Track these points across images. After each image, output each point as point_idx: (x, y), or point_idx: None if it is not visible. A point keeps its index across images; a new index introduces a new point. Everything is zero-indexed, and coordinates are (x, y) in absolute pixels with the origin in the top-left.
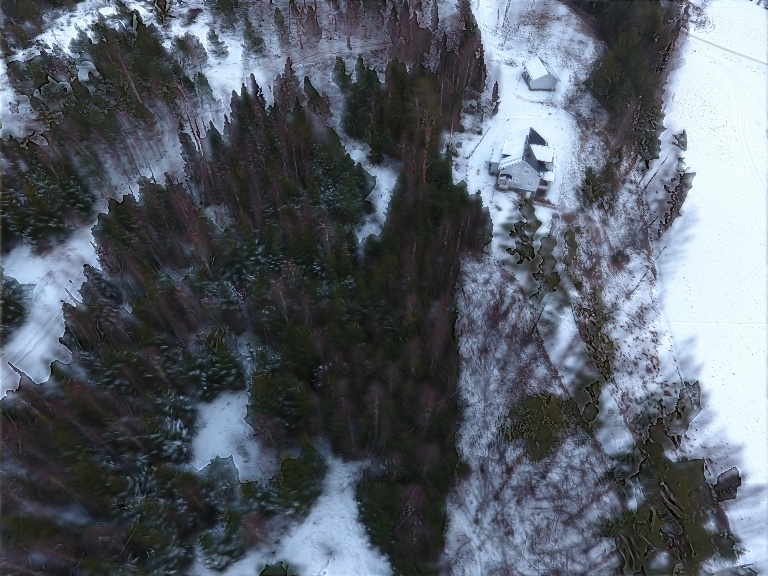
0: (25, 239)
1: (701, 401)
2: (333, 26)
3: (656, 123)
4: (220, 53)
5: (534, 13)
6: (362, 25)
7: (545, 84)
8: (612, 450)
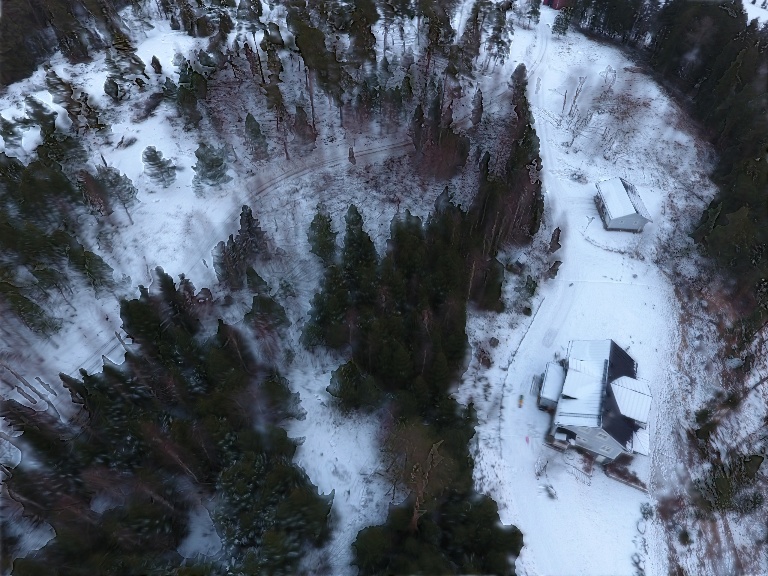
0: None
1: None
2: (338, 120)
3: None
4: (165, 175)
5: (612, 94)
6: (376, 121)
7: (629, 223)
8: None
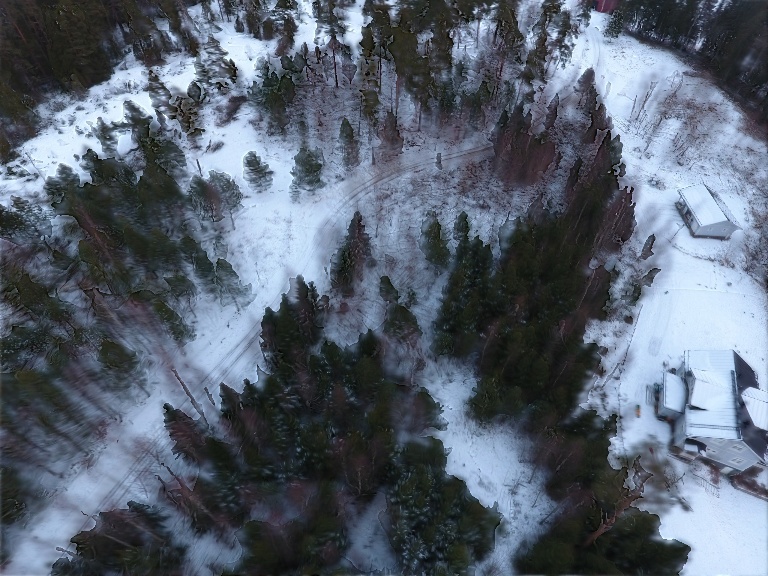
0: None
1: None
2: (416, 124)
3: None
4: (261, 180)
5: (676, 98)
6: (455, 126)
7: (717, 230)
8: None
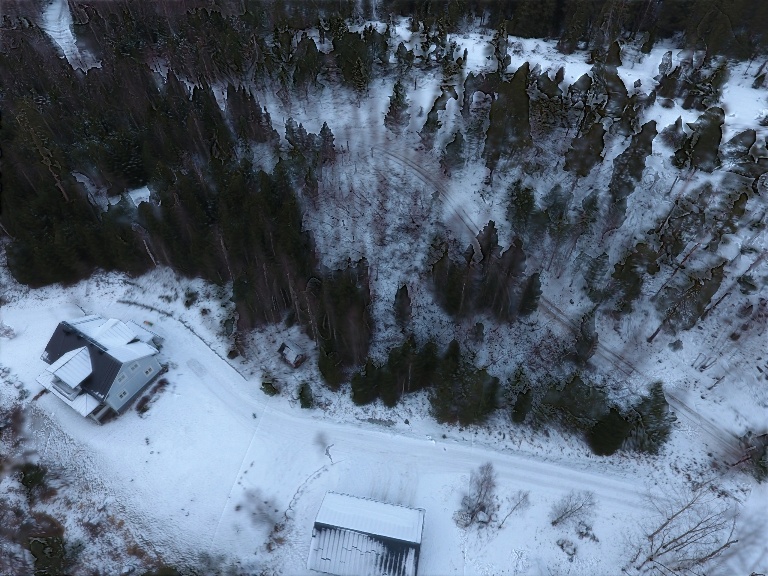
0: (166, 58)
1: None
2: None
3: None
4: None
5: None
6: None
7: None
8: None
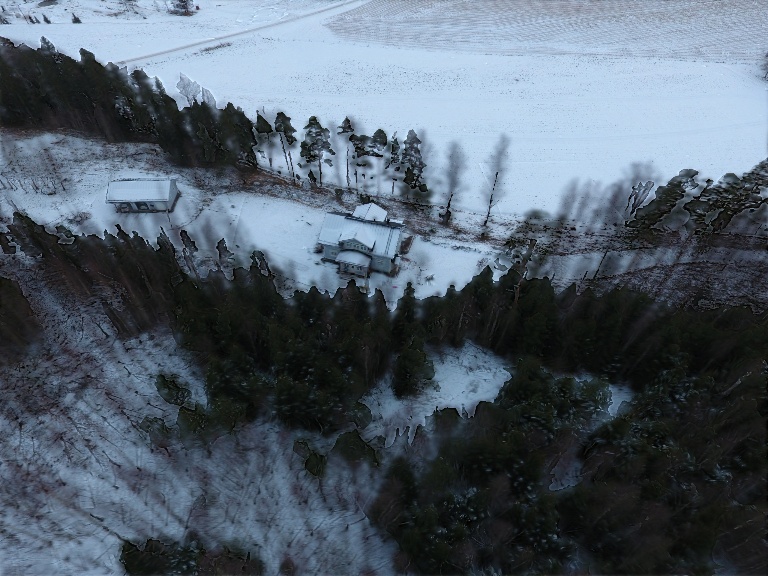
0: None
1: (569, 216)
2: None
3: (319, 131)
4: None
5: None
6: None
7: (172, 194)
8: (650, 262)
